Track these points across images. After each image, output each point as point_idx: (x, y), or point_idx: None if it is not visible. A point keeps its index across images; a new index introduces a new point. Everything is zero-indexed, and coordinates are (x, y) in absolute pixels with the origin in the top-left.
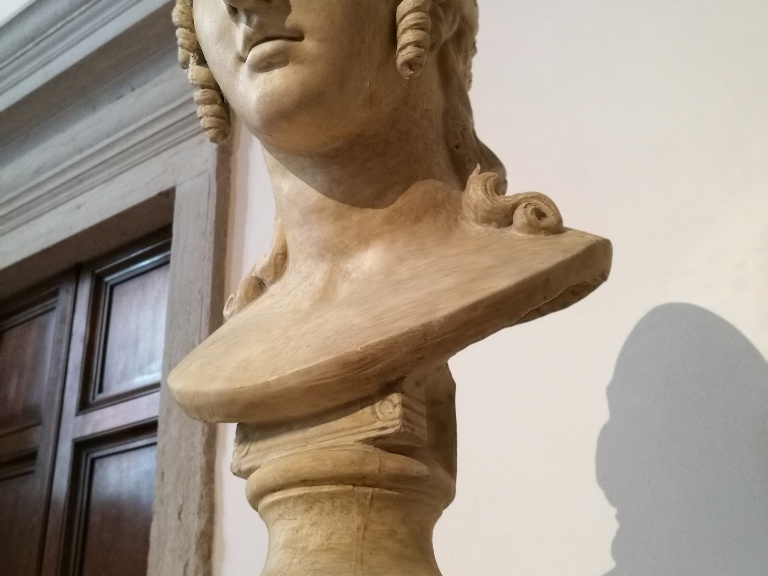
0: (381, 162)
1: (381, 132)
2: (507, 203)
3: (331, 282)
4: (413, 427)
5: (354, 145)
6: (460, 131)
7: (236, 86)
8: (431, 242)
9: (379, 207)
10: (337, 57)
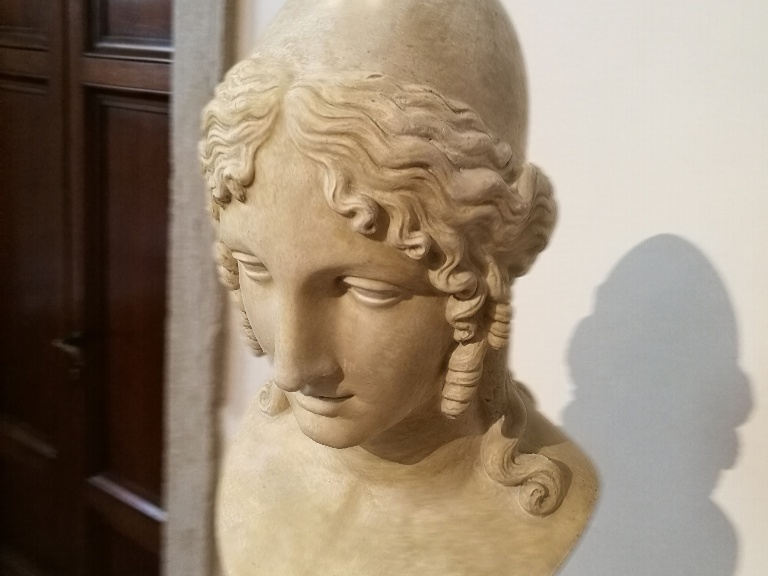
0: (413, 436)
1: (417, 414)
2: (518, 477)
3: (356, 492)
4: None
5: None
6: (493, 390)
7: None
8: (446, 492)
9: (405, 464)
10: (384, 412)
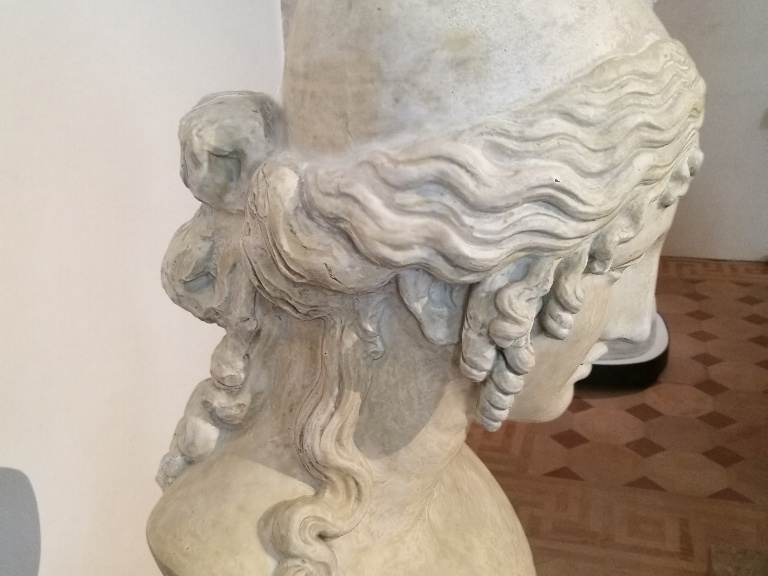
0: None
1: None
2: None
3: None
4: None
5: None
6: None
7: None
8: None
9: None
10: None
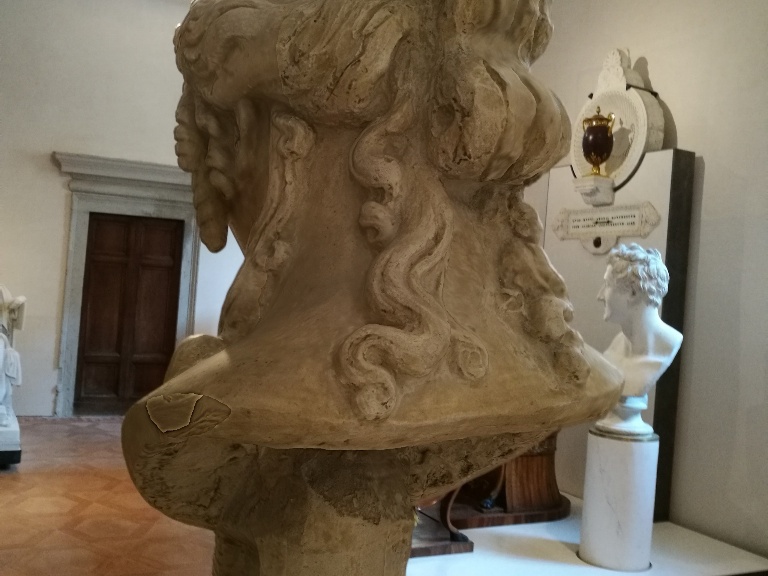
0: None
1: None
2: None
3: None
4: (213, 571)
5: None
6: None
7: None
8: None
9: None
10: None
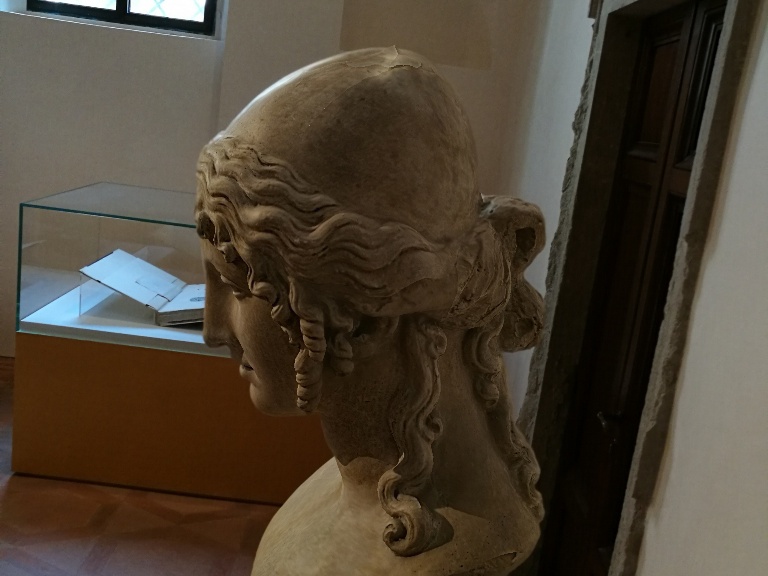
0: (335, 437)
1: (332, 417)
2: (391, 510)
3: None
4: None
5: (322, 418)
6: (391, 423)
7: None
8: (364, 503)
9: (341, 463)
10: (269, 389)
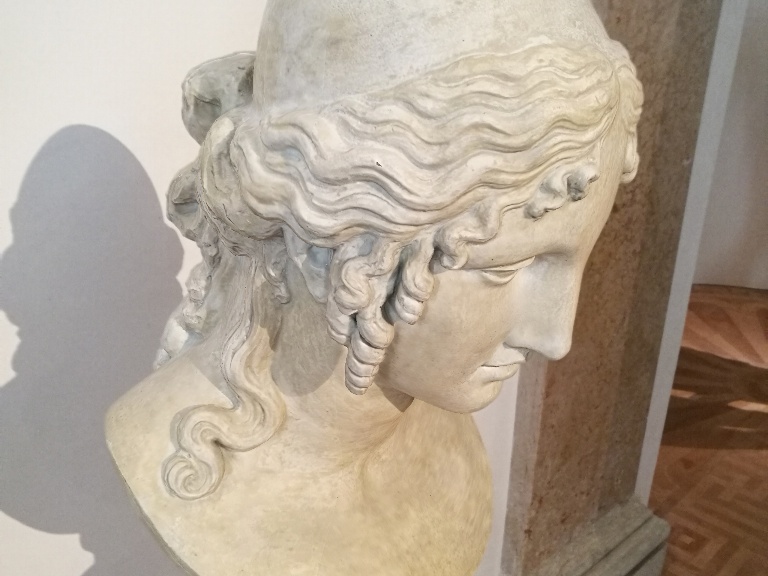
0: None
1: None
2: None
3: None
4: None
5: None
6: None
7: (460, 383)
8: None
9: None
10: None
